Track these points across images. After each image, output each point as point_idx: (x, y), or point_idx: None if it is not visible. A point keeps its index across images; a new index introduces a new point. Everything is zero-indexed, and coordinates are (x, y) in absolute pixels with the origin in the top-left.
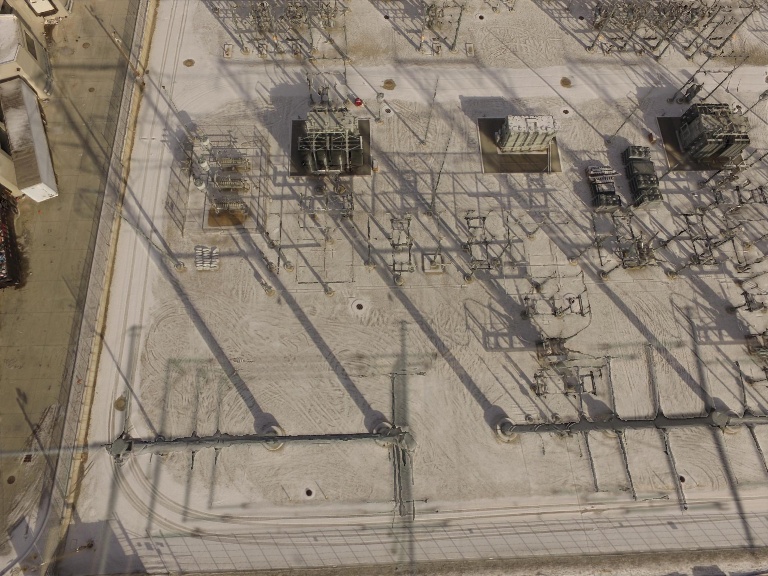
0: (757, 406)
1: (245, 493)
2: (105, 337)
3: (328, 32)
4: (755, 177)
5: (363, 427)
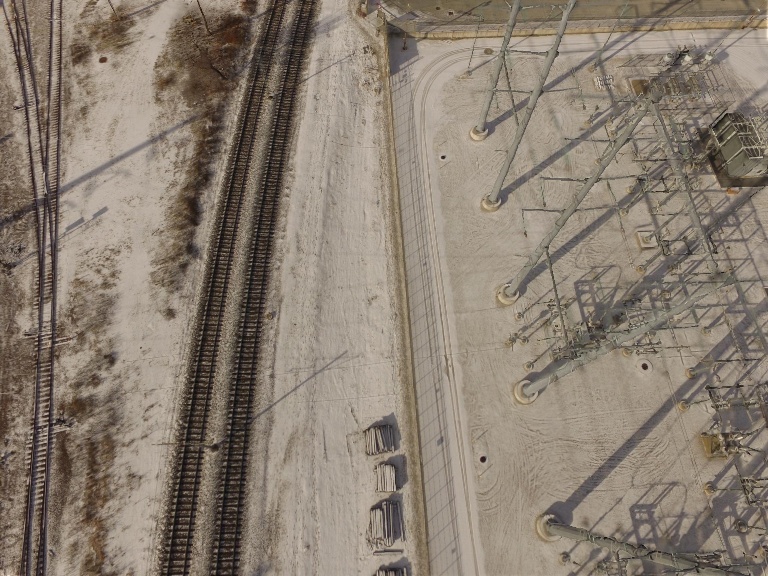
0: (572, 570)
1: (440, 121)
2: (532, 37)
3: None
4: None
5: None
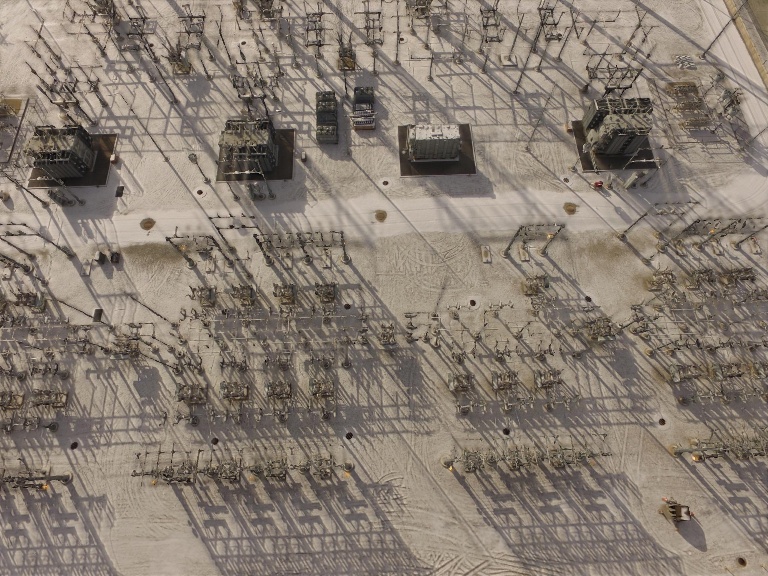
0: None
1: None
2: None
3: None
4: (216, 126)
5: None
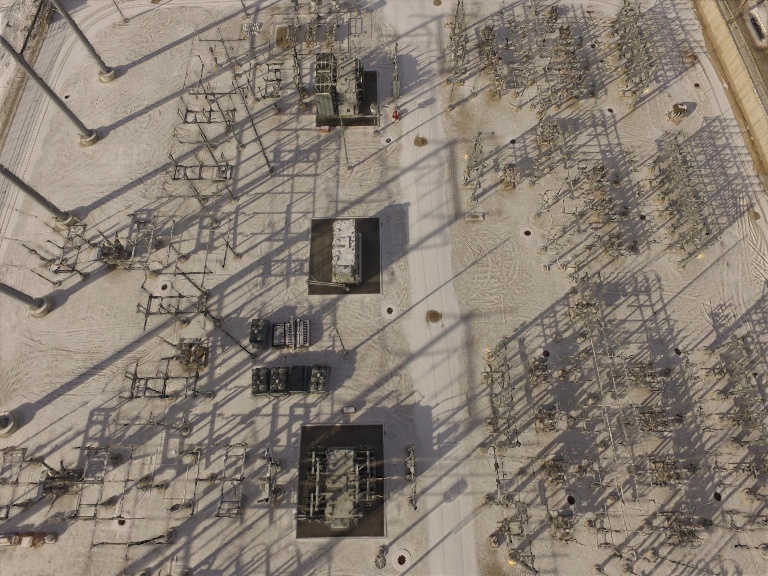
0: None
1: (79, 64)
2: None
3: None
4: (285, 550)
5: (100, 126)
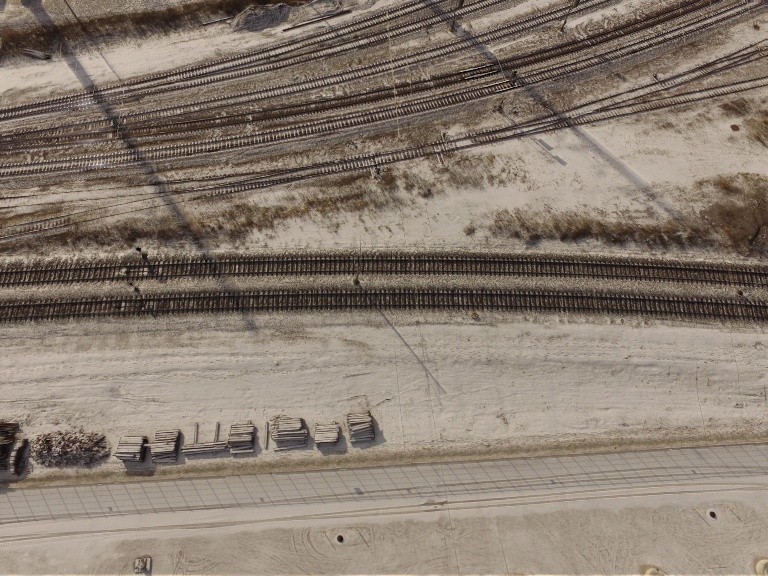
0: None
1: None
2: None
3: None
4: None
5: None
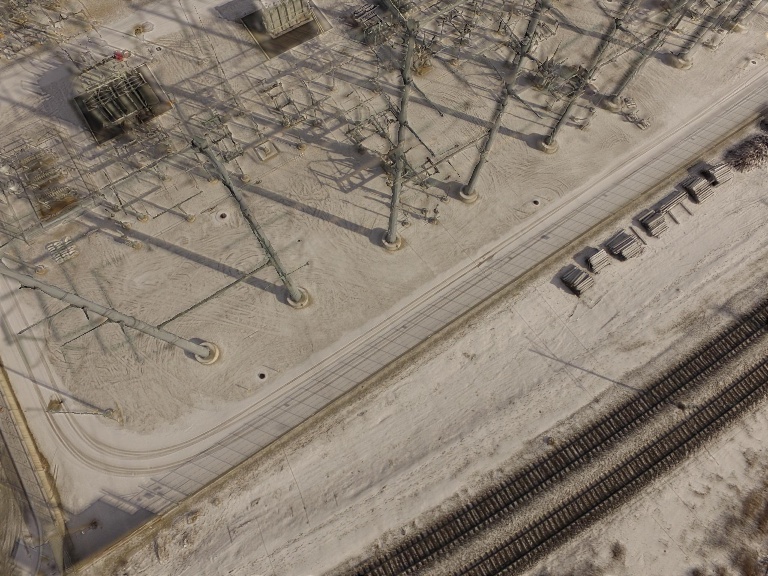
0: None
1: (208, 408)
2: (4, 364)
3: (63, 7)
4: None
5: (278, 303)
